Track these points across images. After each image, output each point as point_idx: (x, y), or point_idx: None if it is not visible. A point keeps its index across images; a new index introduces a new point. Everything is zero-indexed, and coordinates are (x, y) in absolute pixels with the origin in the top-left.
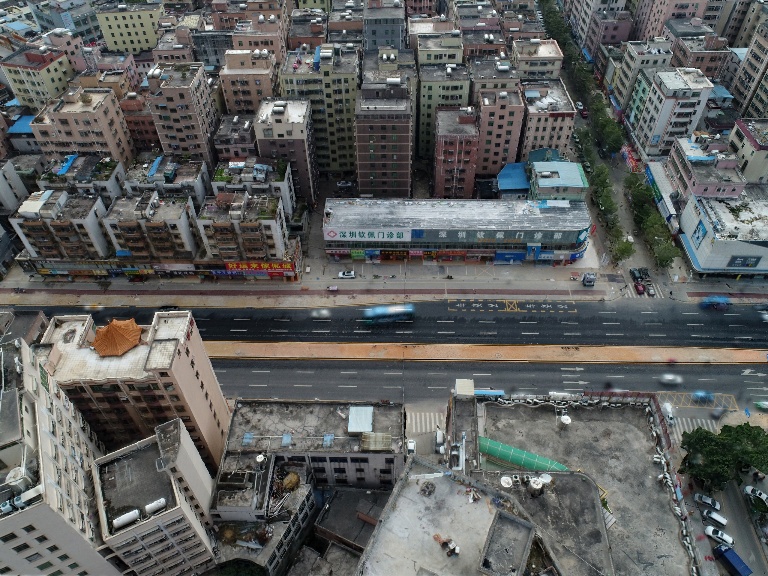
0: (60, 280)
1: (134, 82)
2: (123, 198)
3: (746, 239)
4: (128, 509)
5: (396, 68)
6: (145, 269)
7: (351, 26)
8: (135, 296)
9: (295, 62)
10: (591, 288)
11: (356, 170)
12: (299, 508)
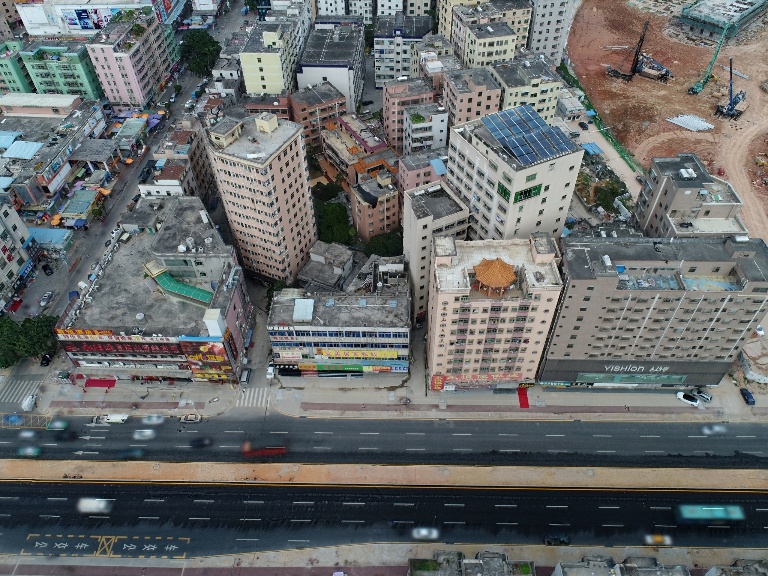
0: None
1: None
2: None
3: None
4: (437, 196)
5: None
6: None
7: None
8: None
9: None
10: None
11: None
12: None
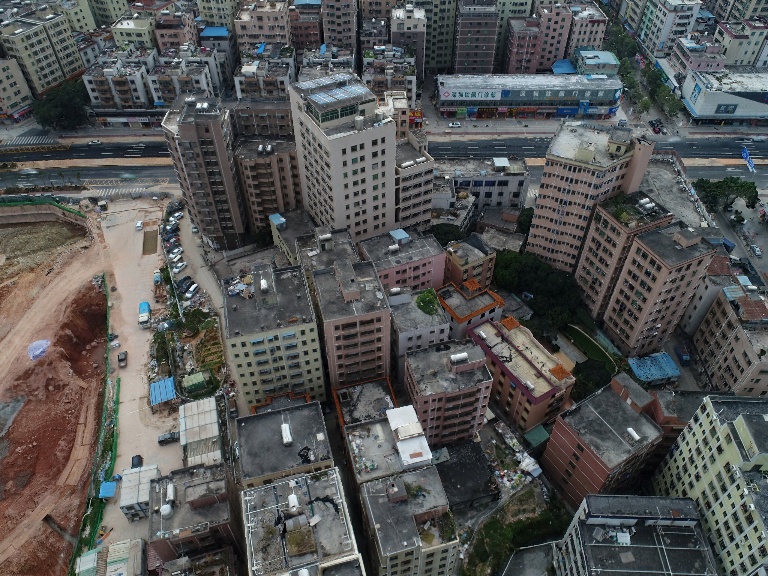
0: None
1: None
2: (307, 67)
3: (727, 91)
4: None
5: None
6: None
7: None
8: None
9: None
10: None
11: (455, 59)
12: None
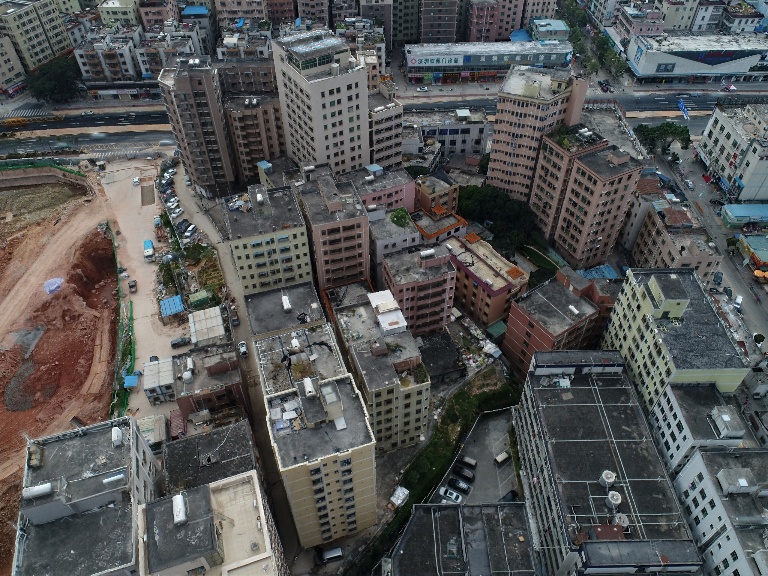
0: None
1: None
2: None
3: (665, 51)
4: None
5: None
6: None
7: None
8: None
9: None
10: None
11: (420, 30)
12: (437, 151)
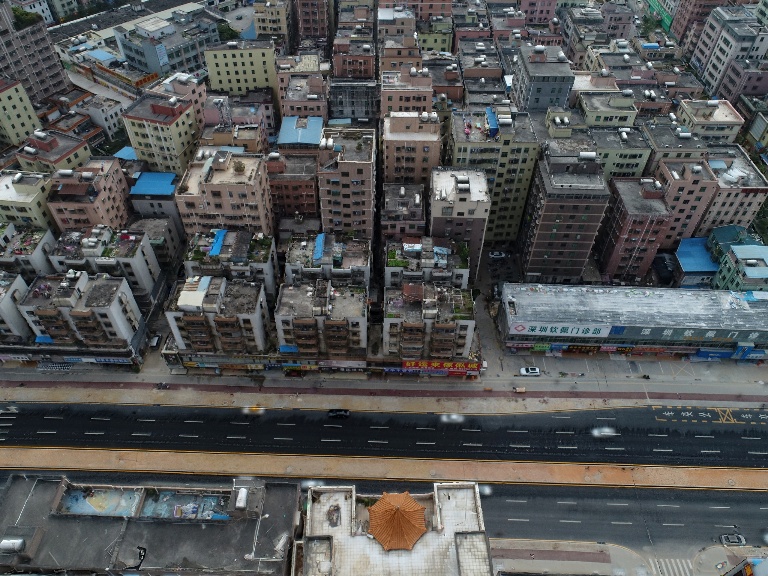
0: (206, 373)
1: (264, 136)
2: (290, 286)
3: None
4: None
5: (570, 133)
6: (308, 365)
7: (488, 74)
8: (296, 395)
9: (466, 126)
10: None
11: (529, 248)
12: None
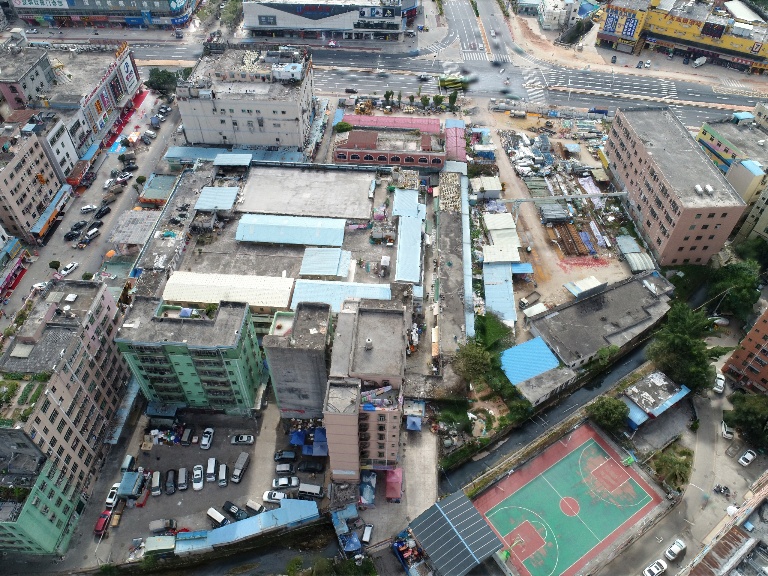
0: None
1: None
2: None
3: (260, 2)
4: None
5: None
6: None
7: None
8: None
9: None
10: (181, 39)
11: None
12: None
